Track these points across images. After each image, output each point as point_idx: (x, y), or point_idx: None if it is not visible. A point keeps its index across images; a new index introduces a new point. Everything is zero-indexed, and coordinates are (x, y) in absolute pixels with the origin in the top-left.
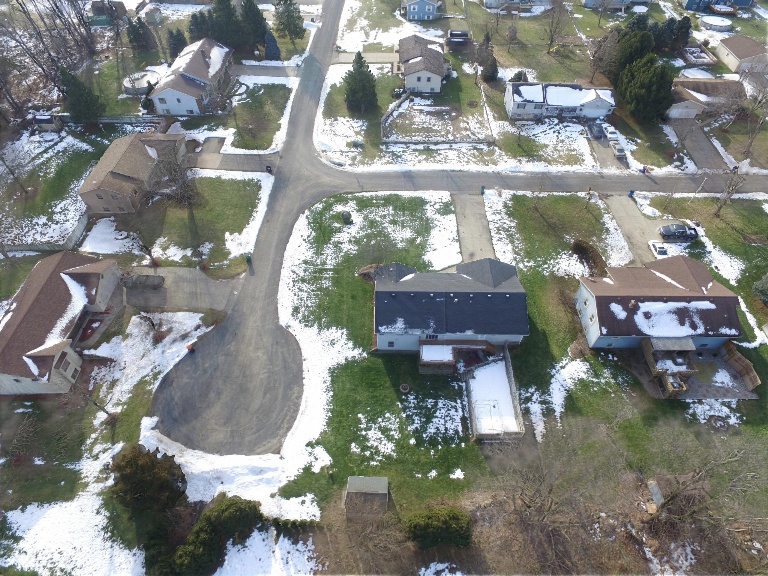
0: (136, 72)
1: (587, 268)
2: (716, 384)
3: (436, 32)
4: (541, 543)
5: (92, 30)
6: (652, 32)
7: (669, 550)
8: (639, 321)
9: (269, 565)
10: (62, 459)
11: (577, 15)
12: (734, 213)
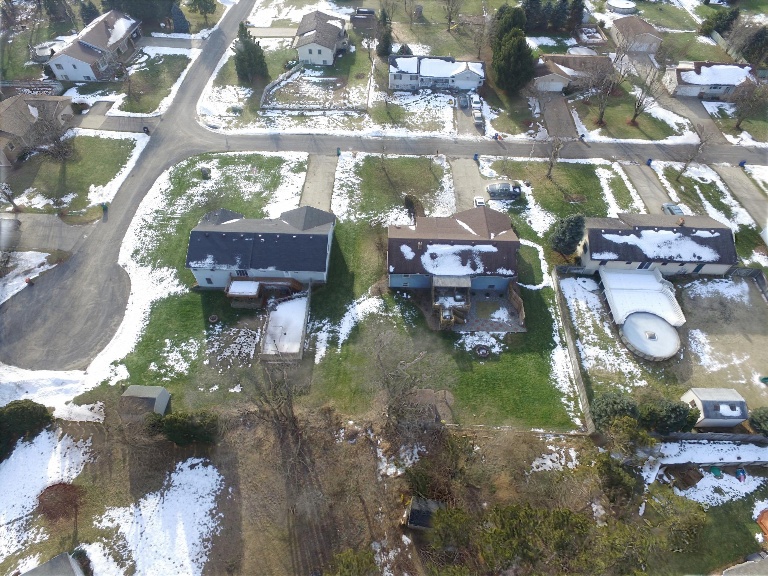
0: (46, 41)
1: (413, 221)
2: (493, 319)
3: (347, 10)
4: (289, 444)
5: (17, 3)
6: (545, 12)
7: (398, 451)
8: (425, 261)
9: (48, 458)
10: None
11: None
12: (566, 175)
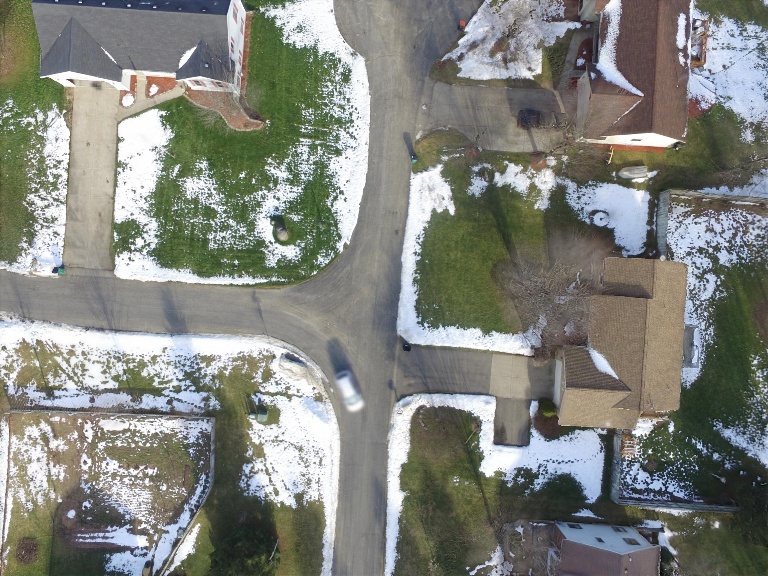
0: None
1: None
2: None
3: None
4: None
5: None
6: None
7: None
8: None
9: None
10: None
11: None
12: None
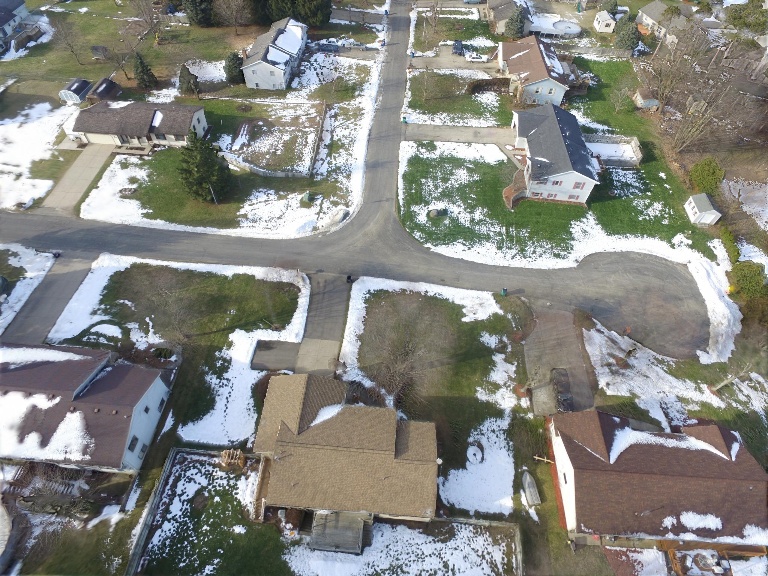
0: None
1: (489, 92)
2: None
3: (39, 109)
4: (686, 150)
5: None
6: None
7: None
8: None
9: None
10: (763, 430)
11: (81, 10)
12: None
